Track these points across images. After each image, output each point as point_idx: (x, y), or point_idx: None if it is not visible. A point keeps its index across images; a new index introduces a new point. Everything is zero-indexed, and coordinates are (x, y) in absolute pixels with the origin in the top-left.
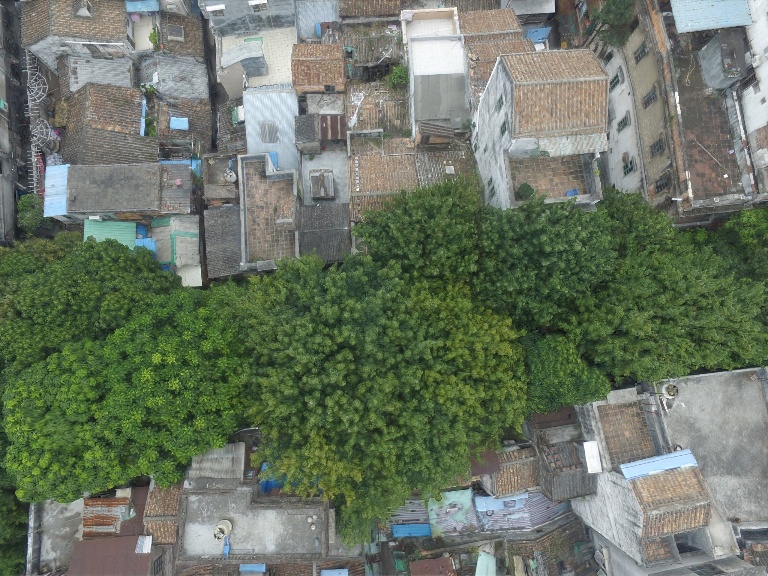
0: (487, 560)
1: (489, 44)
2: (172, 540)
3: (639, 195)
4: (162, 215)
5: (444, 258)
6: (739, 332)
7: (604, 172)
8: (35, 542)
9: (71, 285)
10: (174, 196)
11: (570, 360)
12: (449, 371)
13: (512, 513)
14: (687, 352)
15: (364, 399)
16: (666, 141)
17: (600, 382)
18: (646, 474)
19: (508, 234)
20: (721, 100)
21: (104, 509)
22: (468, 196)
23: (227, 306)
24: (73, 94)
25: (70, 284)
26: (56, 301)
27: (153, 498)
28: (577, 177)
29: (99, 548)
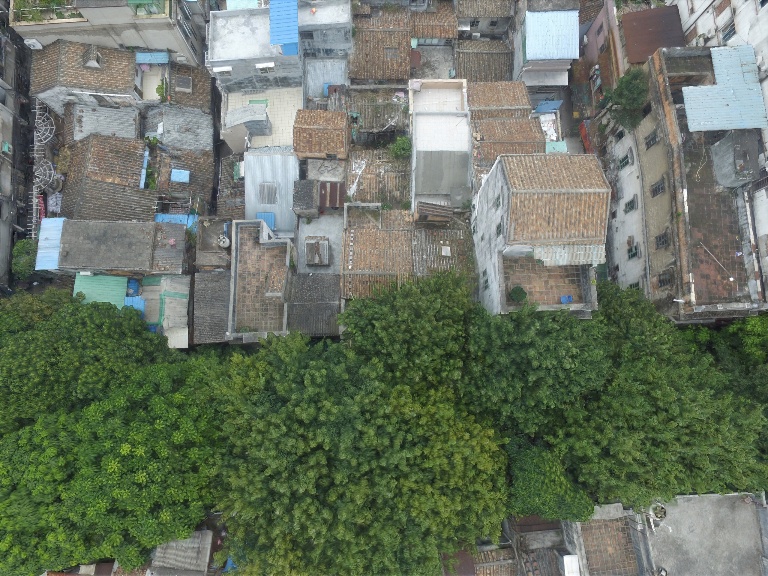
0: None
1: (496, 122)
2: None
3: (640, 292)
4: (153, 274)
5: (428, 361)
6: (733, 462)
7: (608, 251)
8: None
9: (51, 354)
10: (166, 256)
11: (552, 478)
12: (426, 479)
13: None
14: (677, 477)
15: (335, 505)
16: (672, 236)
17: (583, 503)
18: None
19: (495, 343)
20: (732, 198)
21: None
22: (458, 296)
23: (206, 386)
24: (76, 143)
25: (50, 353)
26: (33, 373)
27: None
28: (573, 281)
29: None
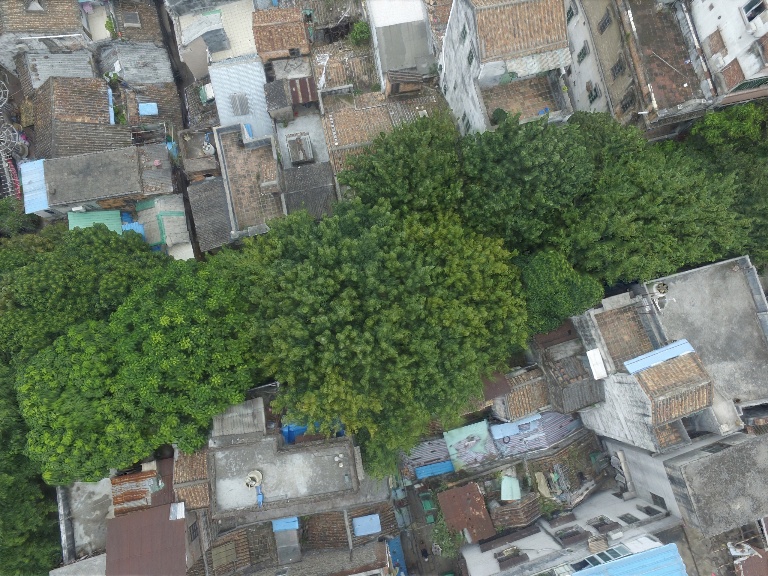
0: (510, 483)
1: None
2: (204, 503)
3: (607, 114)
4: (145, 198)
5: (431, 189)
6: (717, 221)
7: None
8: (67, 529)
9: (66, 269)
10: (155, 177)
11: (563, 269)
12: (450, 297)
13: (528, 436)
14: (671, 248)
15: (373, 333)
16: (625, 60)
17: (594, 287)
18: (648, 367)
19: (489, 156)
20: (672, 14)
21: (132, 485)
22: (445, 127)
23: (225, 269)
24: (36, 91)
25: (65, 268)
26: (54, 285)
27: (179, 466)
28: (546, 98)
29: (133, 521)
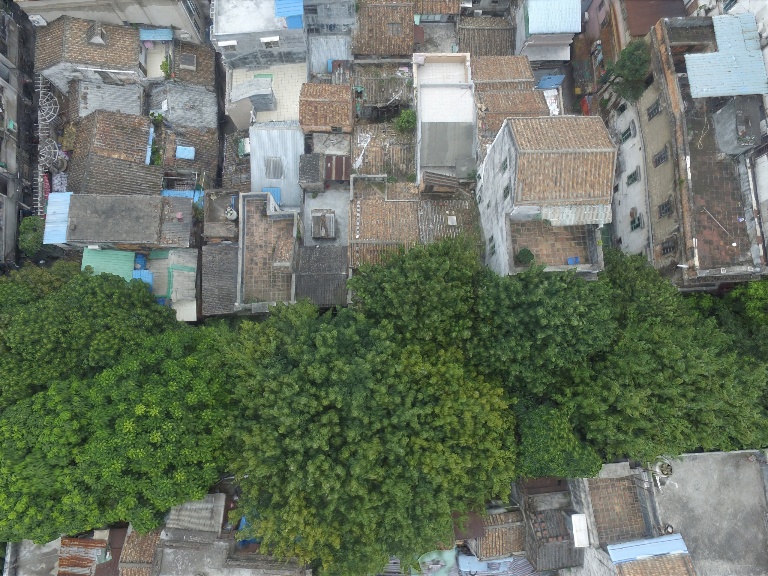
0: None
1: (500, 94)
2: None
3: (644, 258)
4: (161, 247)
5: (438, 322)
6: (738, 417)
7: (611, 224)
8: None
9: (63, 322)
10: (174, 229)
11: (561, 435)
12: (436, 437)
13: (496, 575)
14: (683, 433)
15: (347, 463)
16: (675, 204)
17: (591, 459)
18: (633, 558)
19: (504, 303)
20: (734, 165)
21: (81, 550)
22: (466, 258)
23: (217, 352)
24: (82, 119)
25: (61, 321)
26: (46, 339)
27: (130, 543)
28: (579, 243)
29: None
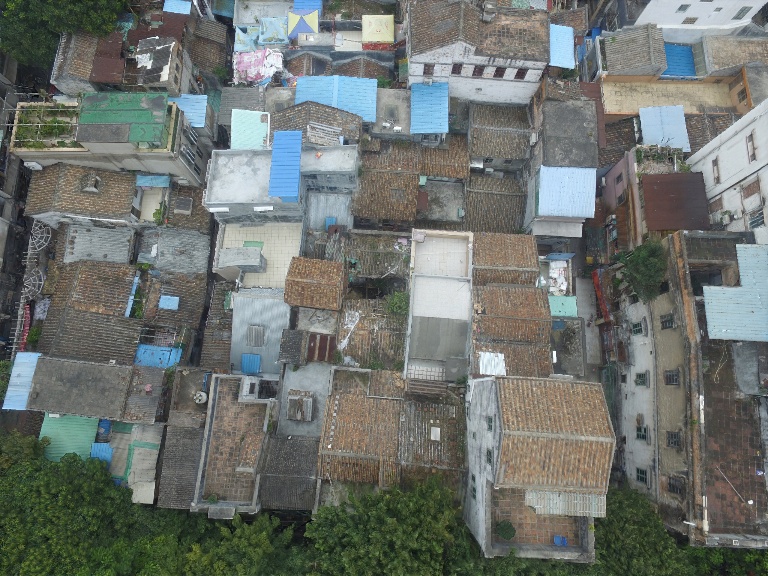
0: None
1: (500, 290)
2: None
3: (646, 504)
4: None
5: None
6: None
7: (616, 419)
8: None
9: None
10: (140, 404)
11: None
12: None
13: None
14: None
15: None
16: (685, 442)
17: None
18: None
19: None
20: (754, 406)
21: None
22: (438, 528)
23: None
24: (65, 266)
25: None
26: None
27: None
28: None
29: None
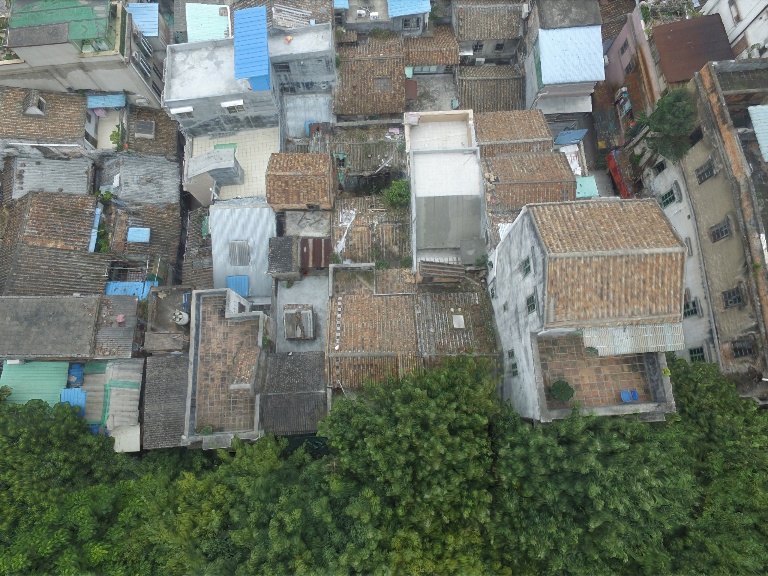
0: None
1: (511, 159)
2: None
3: (714, 368)
4: (97, 359)
5: (442, 494)
6: None
7: None
8: None
9: None
10: (113, 337)
11: None
12: None
13: None
14: None
15: None
16: (748, 294)
17: None
18: None
19: (537, 470)
20: None
21: None
22: (479, 397)
23: (145, 522)
24: (15, 202)
25: None
26: None
27: None
28: (635, 367)
29: None
